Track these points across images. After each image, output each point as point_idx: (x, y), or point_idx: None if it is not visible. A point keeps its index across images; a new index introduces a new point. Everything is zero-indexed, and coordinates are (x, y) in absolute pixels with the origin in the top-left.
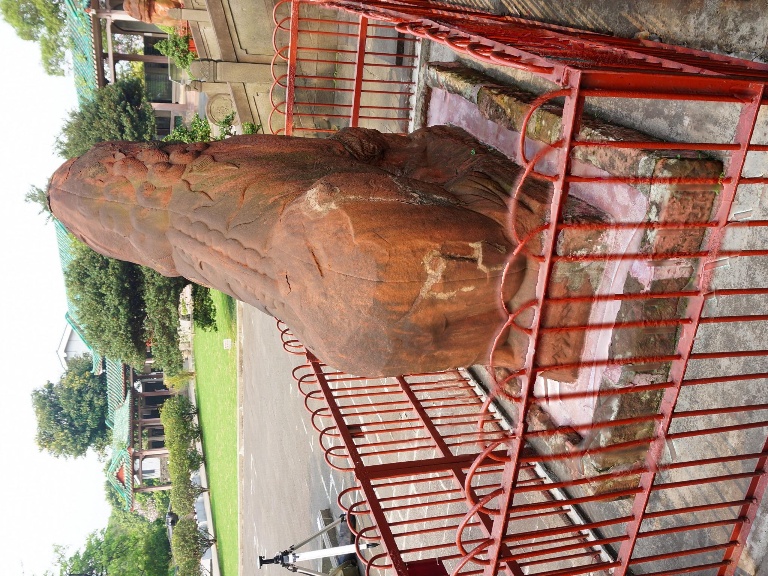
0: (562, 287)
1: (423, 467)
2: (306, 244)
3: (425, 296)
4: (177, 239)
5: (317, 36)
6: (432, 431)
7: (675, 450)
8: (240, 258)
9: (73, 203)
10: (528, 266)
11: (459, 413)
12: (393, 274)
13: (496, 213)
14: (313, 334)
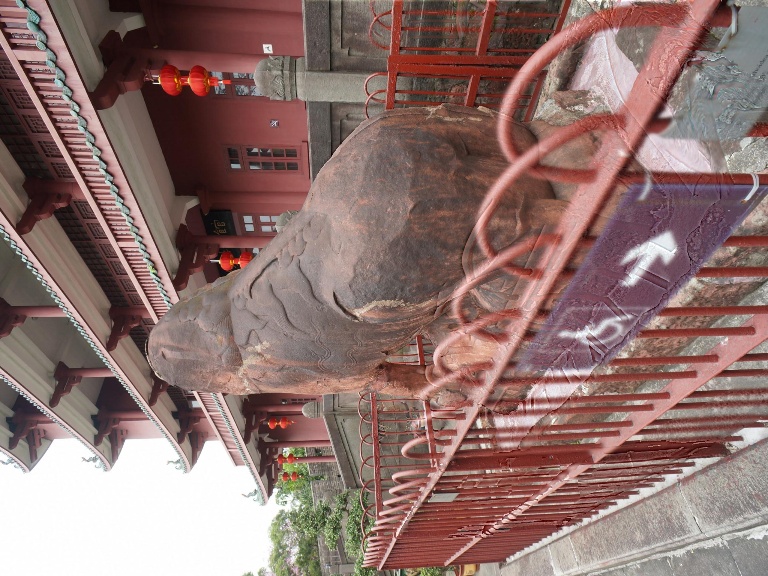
0: (578, 126)
1: None
2: None
3: (431, 117)
4: (235, 286)
5: None
6: None
7: None
8: None
9: None
10: (536, 133)
11: (597, 485)
12: None
13: None
14: (334, 207)
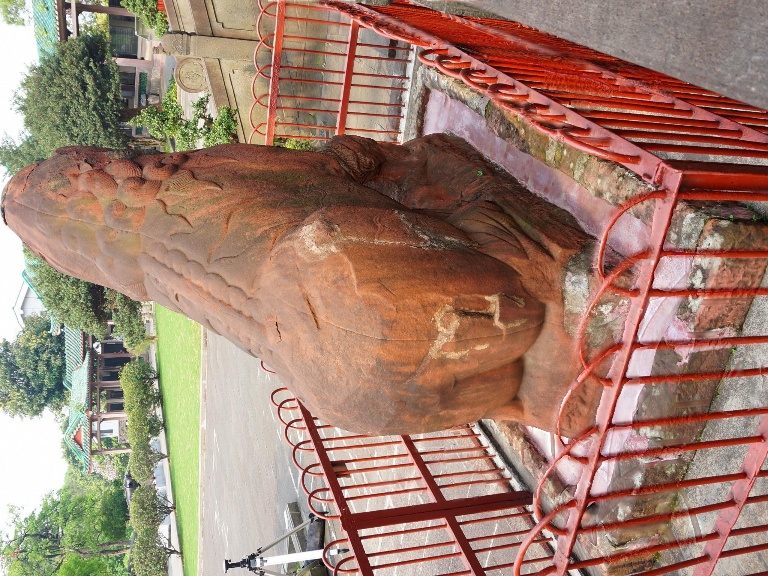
0: (583, 343)
1: (414, 515)
2: (300, 290)
3: (435, 356)
4: (150, 267)
5: (305, 24)
6: (423, 470)
7: (701, 530)
8: (223, 296)
9: (31, 219)
10: (546, 319)
11: (451, 448)
12: (400, 332)
13: (514, 259)
14: (305, 388)
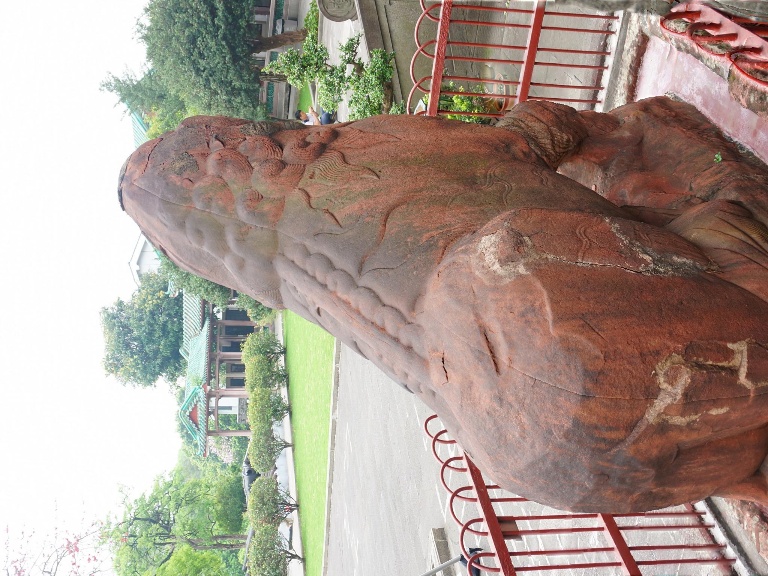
0: None
1: None
2: (476, 321)
3: (653, 420)
4: (288, 272)
5: None
6: (616, 539)
7: None
8: (376, 317)
9: (152, 206)
10: None
11: None
12: (608, 387)
13: None
14: (475, 444)
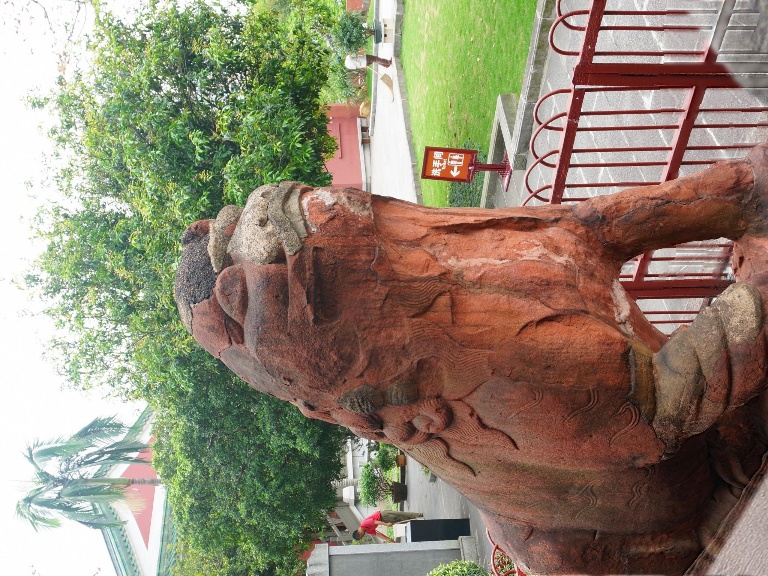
0: None
1: None
2: None
3: None
4: None
5: None
6: None
7: None
8: None
9: None
10: None
11: None
12: None
13: None
14: None
